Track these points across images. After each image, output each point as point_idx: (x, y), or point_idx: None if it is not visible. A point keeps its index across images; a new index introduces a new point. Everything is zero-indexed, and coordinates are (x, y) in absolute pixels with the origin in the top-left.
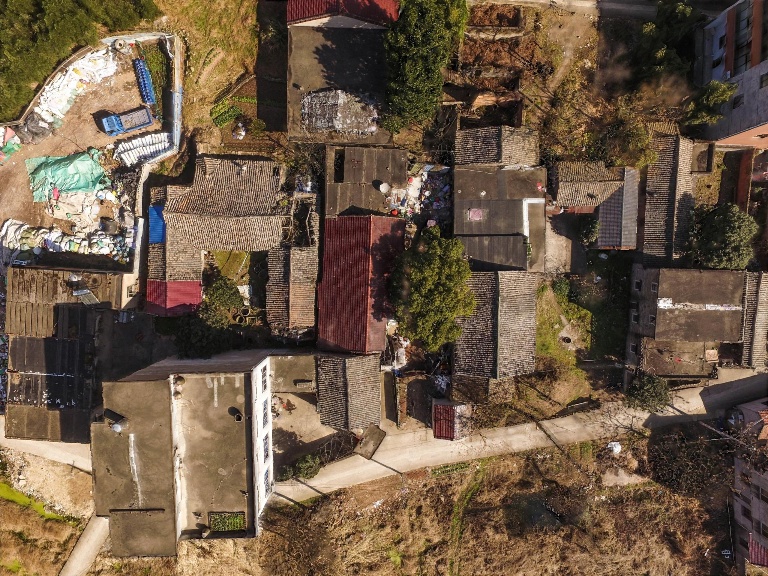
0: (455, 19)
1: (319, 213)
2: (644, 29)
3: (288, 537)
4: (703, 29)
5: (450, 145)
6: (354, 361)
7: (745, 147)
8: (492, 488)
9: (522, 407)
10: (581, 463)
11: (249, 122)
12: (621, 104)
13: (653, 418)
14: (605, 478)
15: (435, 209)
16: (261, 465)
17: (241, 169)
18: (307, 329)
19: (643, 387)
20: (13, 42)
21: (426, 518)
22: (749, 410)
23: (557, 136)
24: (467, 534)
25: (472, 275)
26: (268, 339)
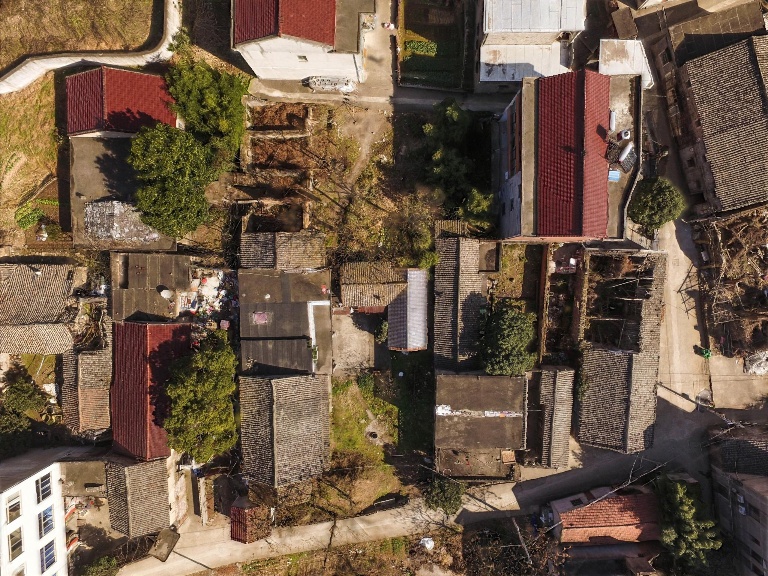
0: (225, 129)
1: None
2: None
3: None
4: (498, 122)
5: (234, 249)
6: (136, 468)
7: (539, 243)
8: None
9: (325, 505)
10: (395, 559)
11: None
12: (406, 204)
13: (465, 514)
14: (420, 574)
15: (233, 307)
16: None
17: None
18: (106, 429)
19: (432, 492)
20: None
21: None
22: (555, 510)
23: (351, 233)
24: None
25: (253, 381)
26: None
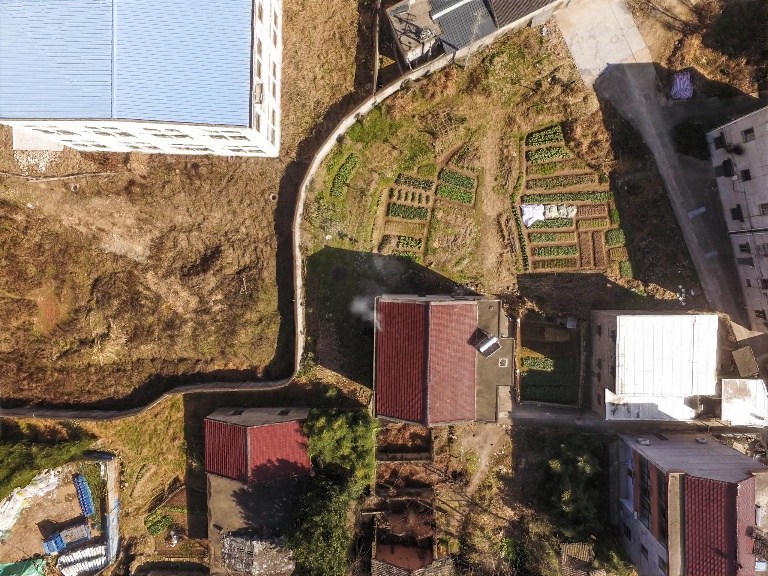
0: (361, 474)
1: None
2: (550, 464)
3: None
4: None
5: (366, 575)
6: None
7: None
8: None
9: None
10: None
11: (180, 530)
12: (532, 531)
13: None
14: None
15: None
16: None
17: None
18: None
19: None
20: None
21: None
22: None
23: (474, 546)
24: None
25: None
26: None
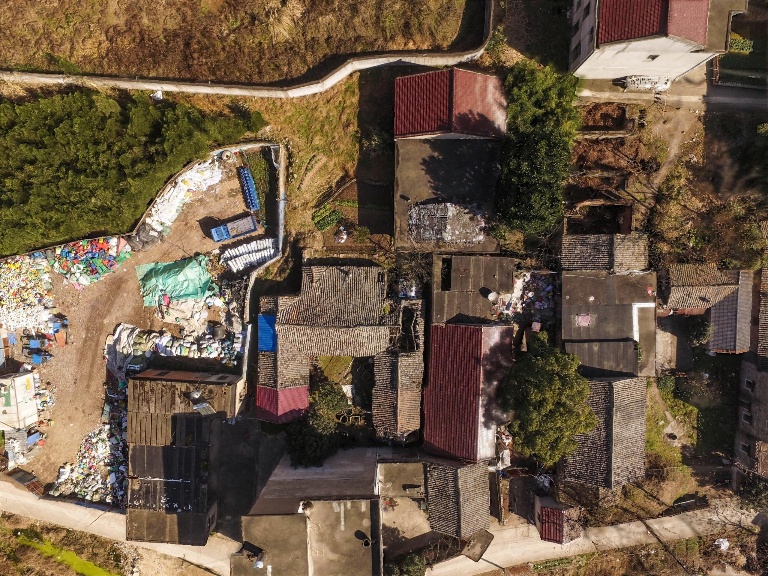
0: (565, 130)
1: (424, 318)
2: (759, 130)
3: None
4: None
5: (557, 251)
6: (465, 470)
7: None
8: None
9: (628, 506)
10: (687, 559)
11: (350, 225)
12: (733, 205)
13: (763, 515)
14: (712, 574)
15: (537, 309)
16: None
17: (346, 276)
18: (412, 430)
19: (760, 494)
20: (132, 164)
21: None
22: None
23: (663, 234)
24: None
25: None
26: (371, 438)
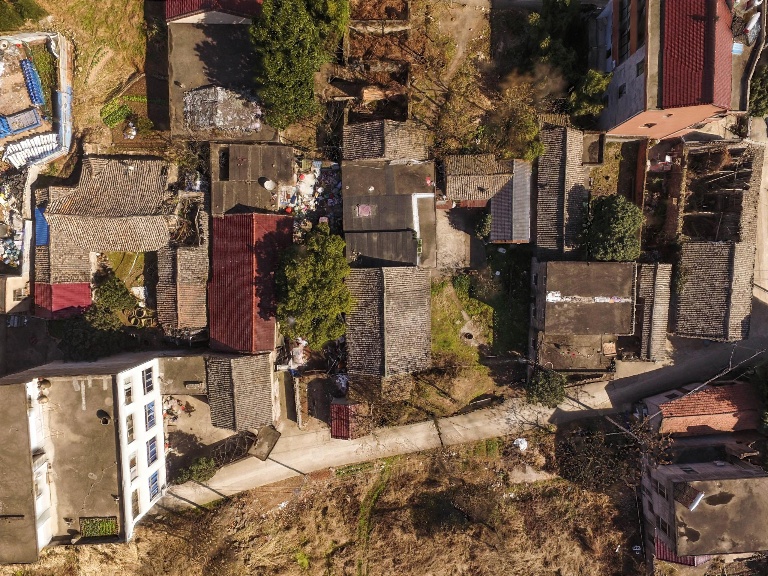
0: (333, 13)
1: (208, 212)
2: (529, 20)
3: (192, 541)
4: (596, 19)
5: (337, 141)
6: (241, 361)
7: (639, 137)
8: (399, 487)
9: (422, 405)
10: (488, 460)
11: None
12: (510, 96)
13: (558, 413)
14: (513, 475)
15: (329, 206)
16: (141, 469)
17: (128, 169)
18: (201, 330)
19: (537, 382)
20: None
21: (331, 519)
22: (651, 403)
23: (450, 130)
24: (374, 535)
25: (359, 272)
26: (164, 341)
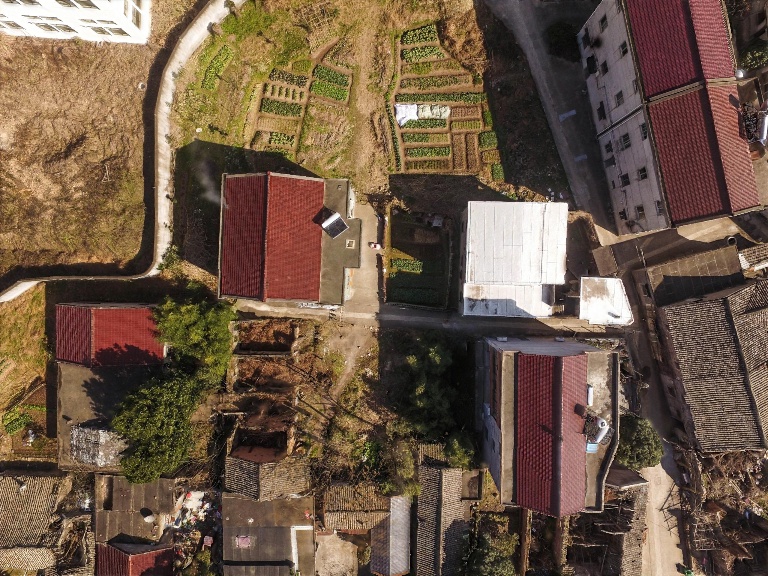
0: (212, 362)
1: None
2: None
3: None
4: None
5: (219, 471)
6: None
7: None
8: None
9: None
10: None
11: (39, 429)
12: (390, 429)
13: None
14: None
15: (218, 518)
16: None
17: None
18: None
19: None
20: None
21: None
22: None
23: (336, 449)
24: None
25: None
26: None
